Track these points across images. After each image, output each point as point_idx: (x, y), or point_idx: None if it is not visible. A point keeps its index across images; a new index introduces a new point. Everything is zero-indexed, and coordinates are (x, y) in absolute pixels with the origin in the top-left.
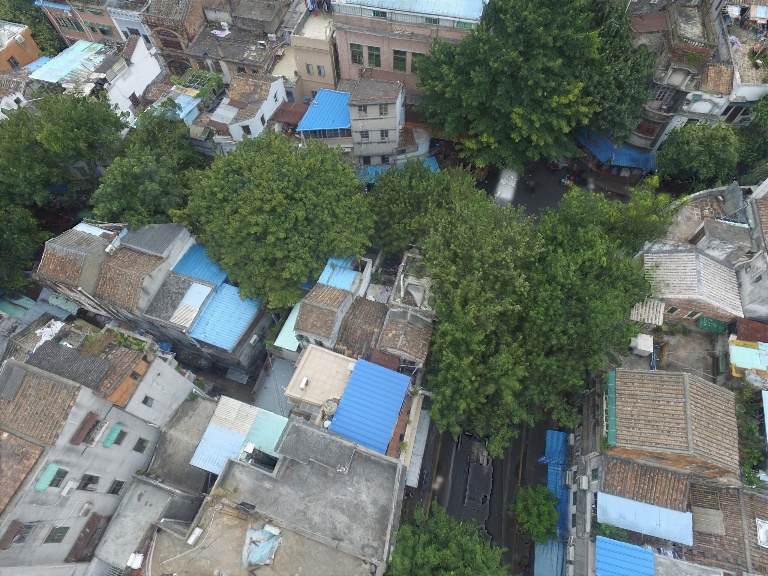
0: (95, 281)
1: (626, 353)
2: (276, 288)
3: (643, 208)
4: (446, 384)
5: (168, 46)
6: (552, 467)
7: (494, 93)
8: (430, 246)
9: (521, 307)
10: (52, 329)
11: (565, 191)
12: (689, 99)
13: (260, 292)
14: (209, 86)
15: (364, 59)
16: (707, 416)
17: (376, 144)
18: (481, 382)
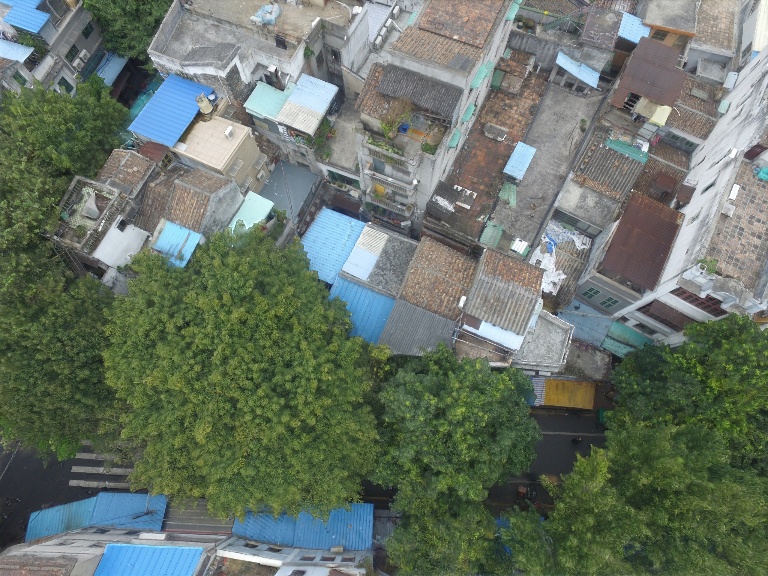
0: None
1: None
2: None
3: None
4: None
5: None
6: None
7: None
8: None
9: None
10: (549, 280)
11: None
12: None
13: None
14: None
15: None
16: None
17: None
18: None
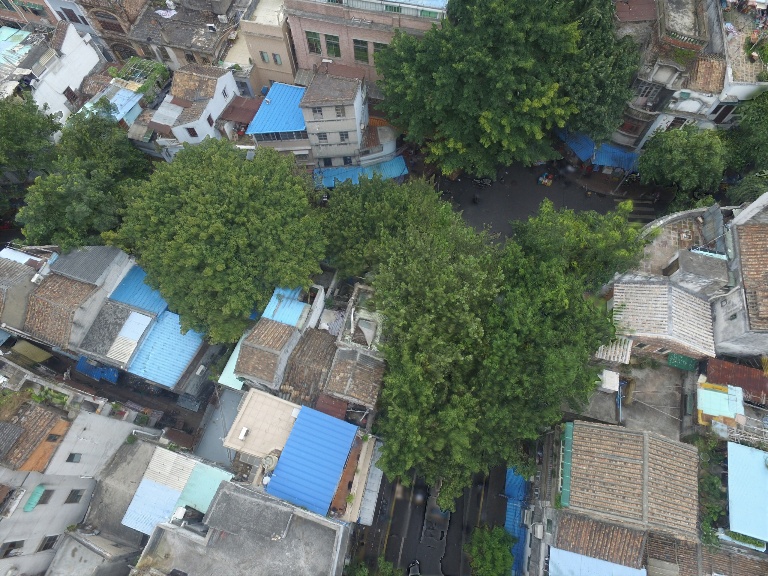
0: (23, 314)
1: (586, 402)
2: (218, 321)
3: (613, 240)
4: (395, 433)
5: (108, 29)
6: (511, 503)
7: (461, 94)
8: (379, 283)
9: (477, 350)
10: None
11: (543, 190)
12: (676, 97)
13: (203, 324)
14: (152, 78)
15: (322, 48)
16: (666, 478)
17: (336, 146)
18: (430, 436)
